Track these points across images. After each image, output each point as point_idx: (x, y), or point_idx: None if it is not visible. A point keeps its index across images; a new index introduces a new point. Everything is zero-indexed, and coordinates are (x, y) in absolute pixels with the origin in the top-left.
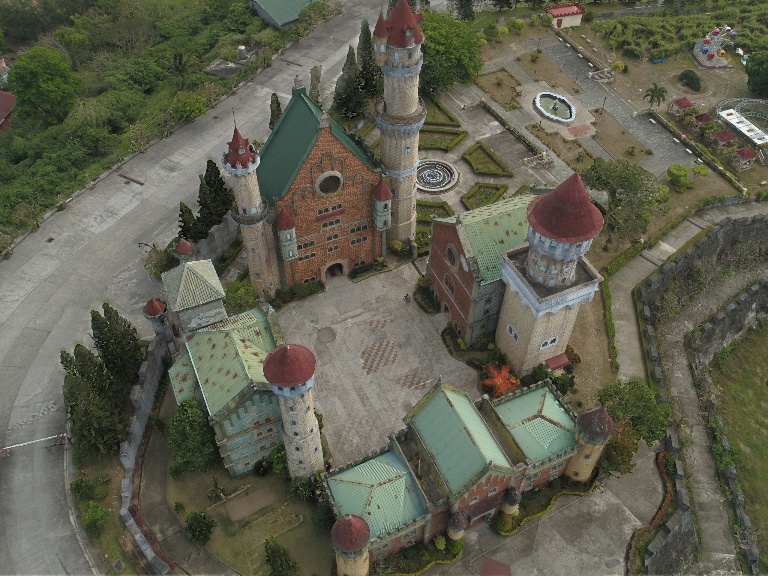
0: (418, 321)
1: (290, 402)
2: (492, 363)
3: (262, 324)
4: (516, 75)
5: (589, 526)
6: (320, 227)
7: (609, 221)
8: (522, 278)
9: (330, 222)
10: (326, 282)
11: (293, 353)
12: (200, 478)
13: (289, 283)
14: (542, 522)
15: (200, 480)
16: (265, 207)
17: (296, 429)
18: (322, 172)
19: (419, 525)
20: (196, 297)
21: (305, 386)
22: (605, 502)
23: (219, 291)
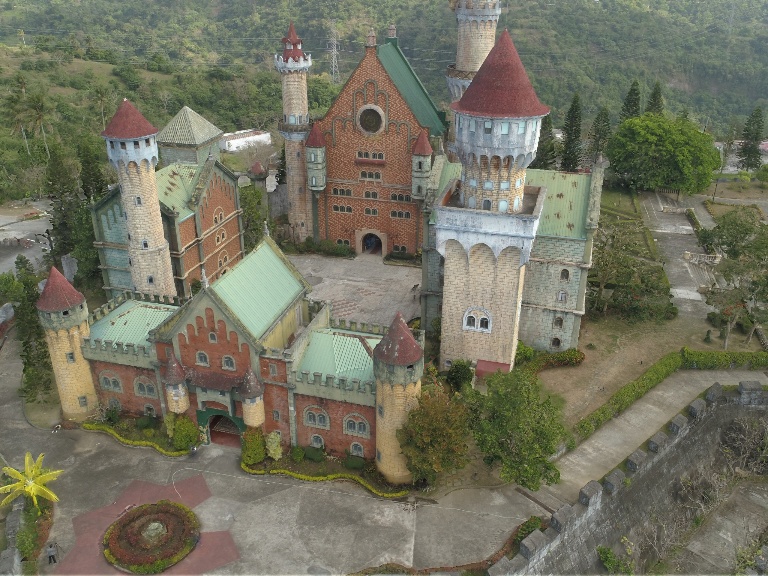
0: (404, 304)
1: (120, 177)
2: (430, 353)
3: (201, 170)
4: (767, 214)
5: (344, 524)
6: (359, 175)
7: (740, 319)
8: (444, 192)
9: (370, 174)
10: (360, 254)
11: (126, 108)
12: (96, 306)
13: (322, 235)
14: (298, 487)
15: (94, 307)
16: (306, 124)
17: (129, 228)
18: (365, 103)
19: (144, 364)
20: (176, 136)
21: (126, 151)
22: (395, 519)
23: (196, 139)
